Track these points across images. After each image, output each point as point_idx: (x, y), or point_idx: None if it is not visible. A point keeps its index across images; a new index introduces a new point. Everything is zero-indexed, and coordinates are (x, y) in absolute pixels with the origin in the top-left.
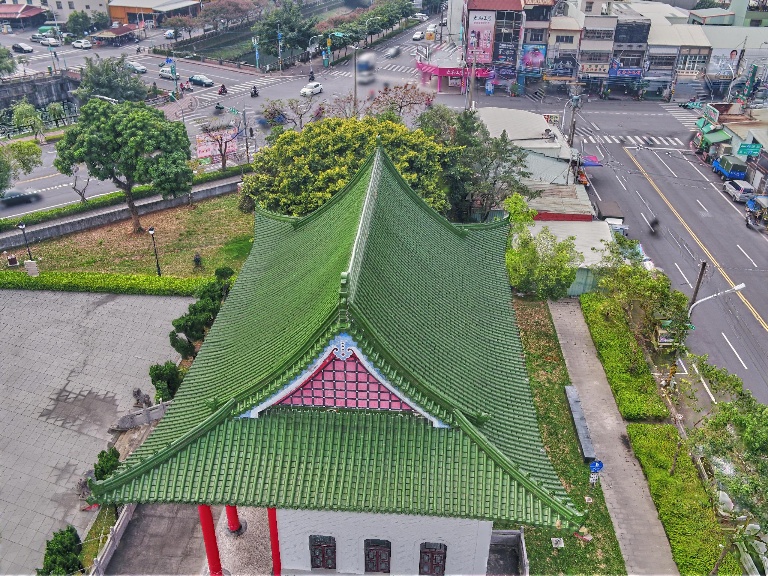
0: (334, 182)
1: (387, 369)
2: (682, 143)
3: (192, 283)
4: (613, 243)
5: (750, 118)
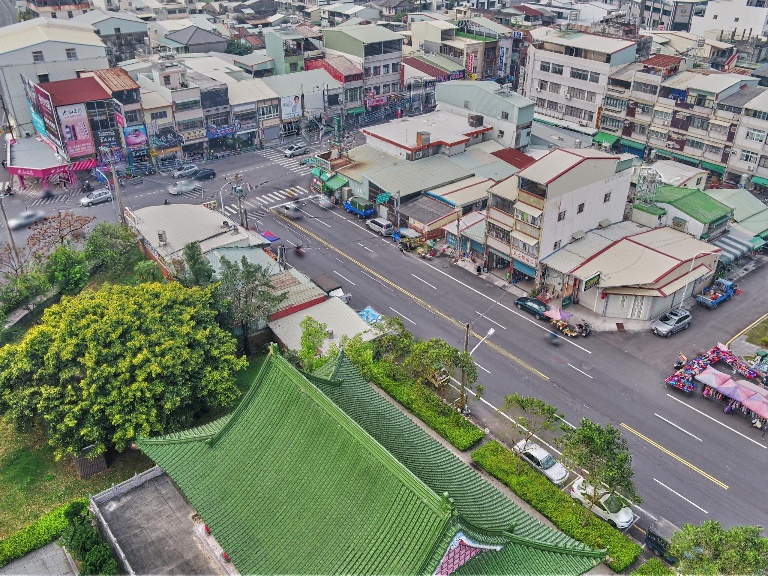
0: (137, 368)
1: (476, 536)
2: (306, 190)
3: (25, 538)
4: (380, 323)
5: (349, 160)
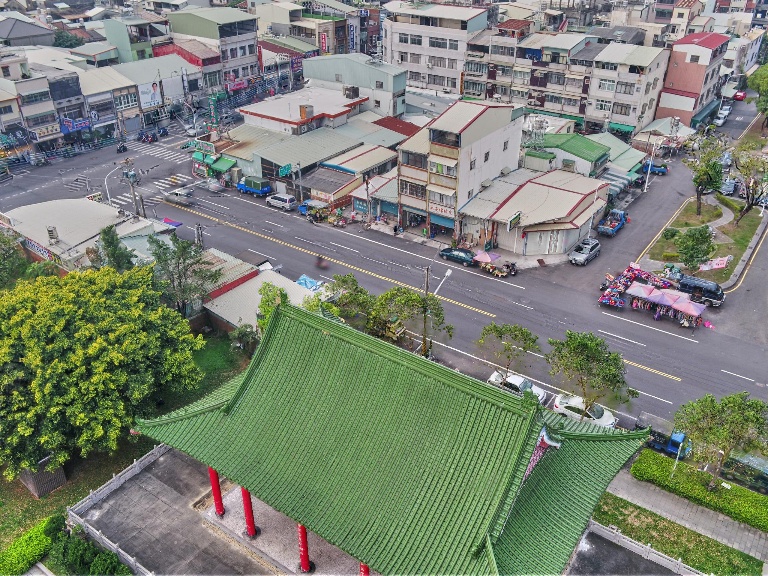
0: (91, 360)
1: None
2: (189, 177)
3: None
4: None
5: (231, 141)
